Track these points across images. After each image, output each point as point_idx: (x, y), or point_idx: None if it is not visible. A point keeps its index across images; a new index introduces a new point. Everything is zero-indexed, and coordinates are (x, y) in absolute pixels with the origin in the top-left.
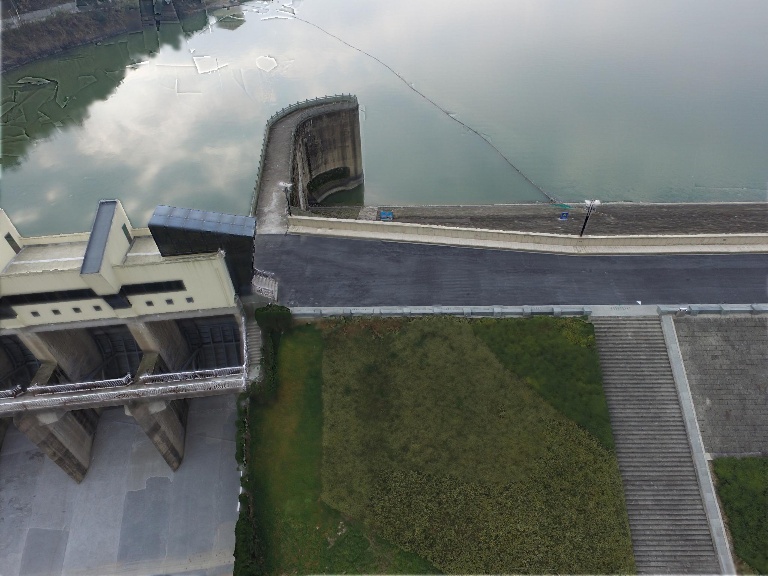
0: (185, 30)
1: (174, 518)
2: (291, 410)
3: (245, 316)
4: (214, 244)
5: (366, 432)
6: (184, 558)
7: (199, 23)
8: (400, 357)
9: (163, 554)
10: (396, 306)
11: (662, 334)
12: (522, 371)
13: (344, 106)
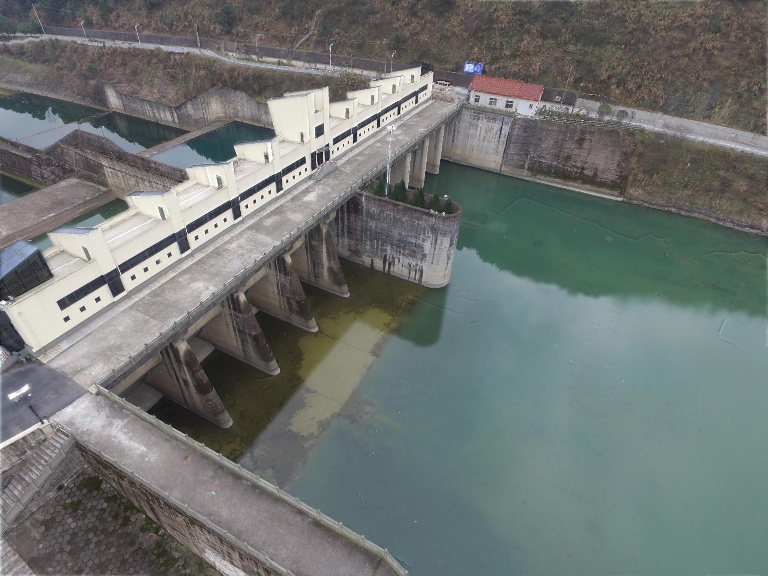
0: None
1: None
2: None
3: None
4: None
5: None
6: None
7: None
8: None
9: None
10: None
11: None
12: None
13: None
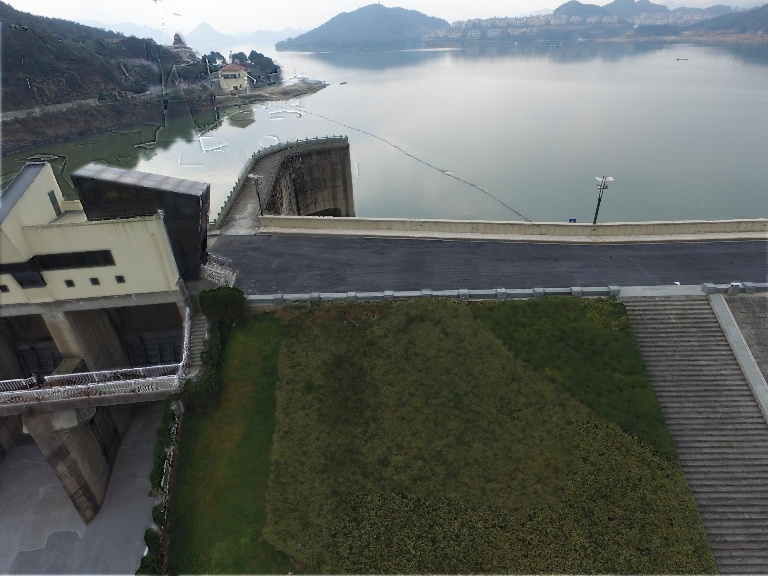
0: (198, 124)
1: None
2: (235, 418)
3: (191, 308)
4: (153, 207)
5: (331, 440)
6: None
7: (211, 119)
8: (379, 345)
9: None
10: (376, 292)
11: (714, 316)
12: (538, 360)
13: (334, 144)
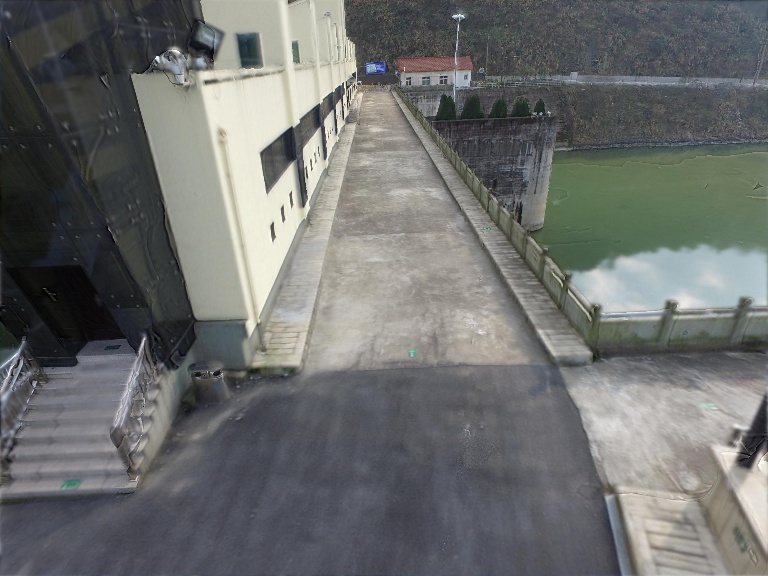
0: None
1: None
2: None
3: None
4: None
5: None
6: None
7: None
8: None
9: None
10: None
11: None
12: None
13: None
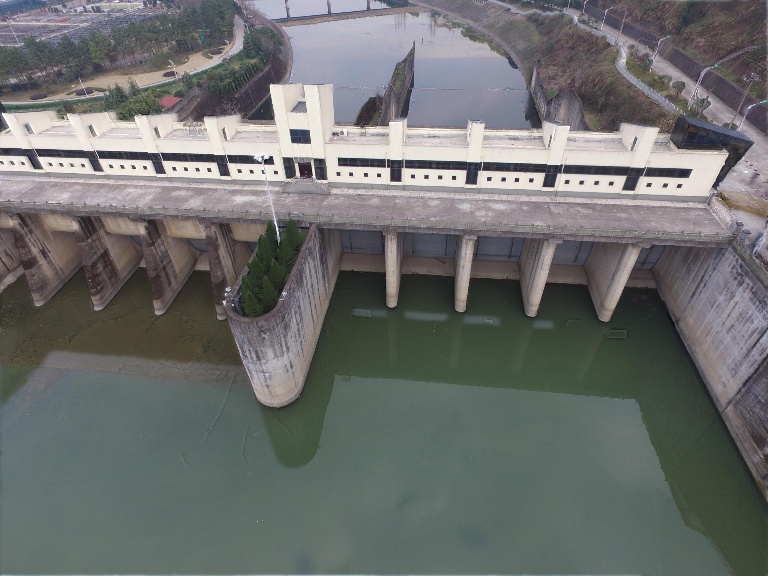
0: None
1: None
2: None
3: None
4: None
5: None
6: None
7: None
8: None
9: None
10: None
11: None
12: None
13: None
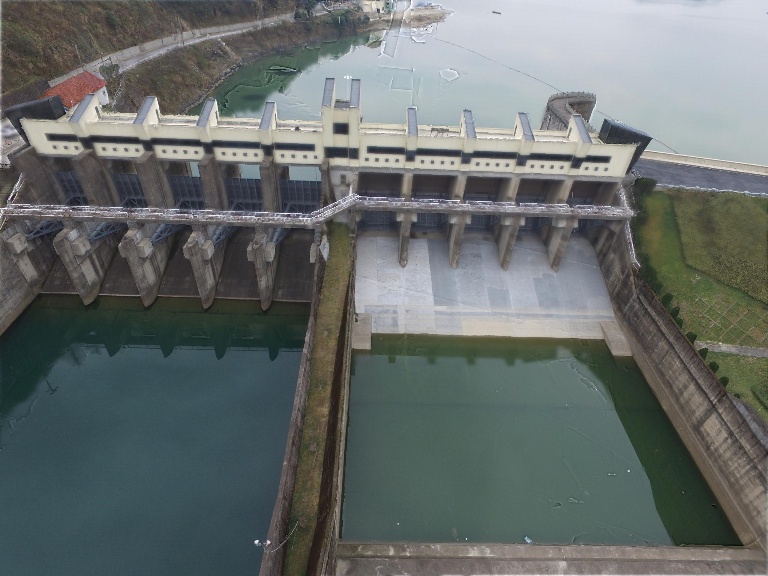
0: (354, 44)
1: (563, 292)
2: (656, 229)
3: None
4: (630, 140)
5: (704, 238)
6: (574, 310)
7: (364, 40)
8: (716, 208)
9: (563, 306)
10: None
11: None
12: None
13: (589, 99)
